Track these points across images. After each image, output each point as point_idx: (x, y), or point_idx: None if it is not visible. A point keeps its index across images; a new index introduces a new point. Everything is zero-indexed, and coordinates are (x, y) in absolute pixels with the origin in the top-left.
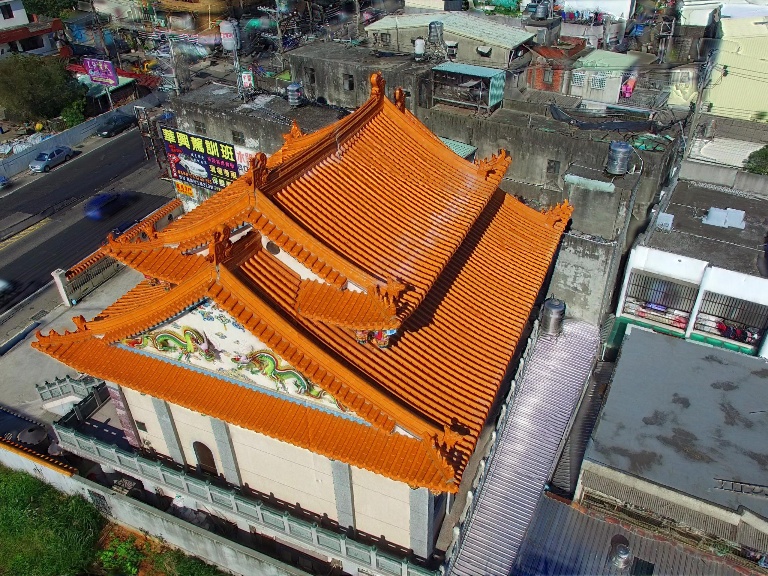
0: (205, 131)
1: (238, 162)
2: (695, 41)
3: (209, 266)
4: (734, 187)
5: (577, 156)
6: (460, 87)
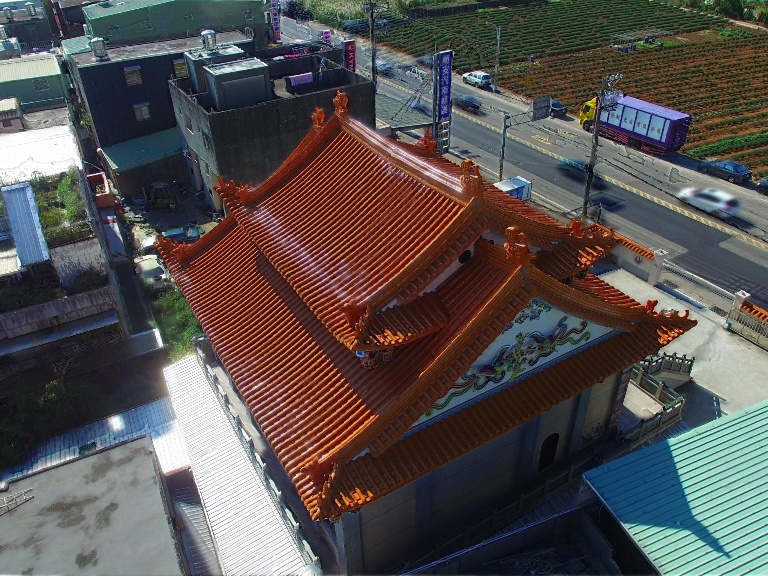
0: None
1: None
2: None
3: None
4: None
5: None
6: None
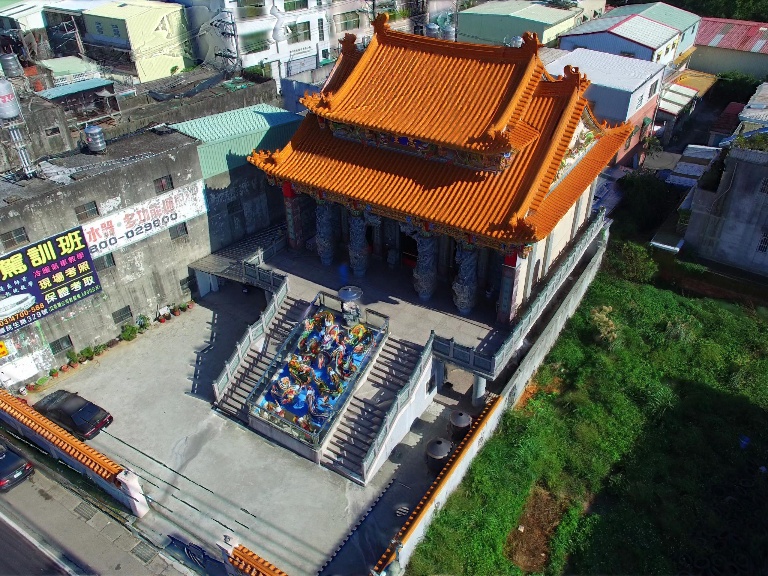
0: (22, 239)
1: (90, 244)
2: (182, 12)
3: (577, 90)
4: (315, 81)
5: (226, 110)
6: (84, 106)
